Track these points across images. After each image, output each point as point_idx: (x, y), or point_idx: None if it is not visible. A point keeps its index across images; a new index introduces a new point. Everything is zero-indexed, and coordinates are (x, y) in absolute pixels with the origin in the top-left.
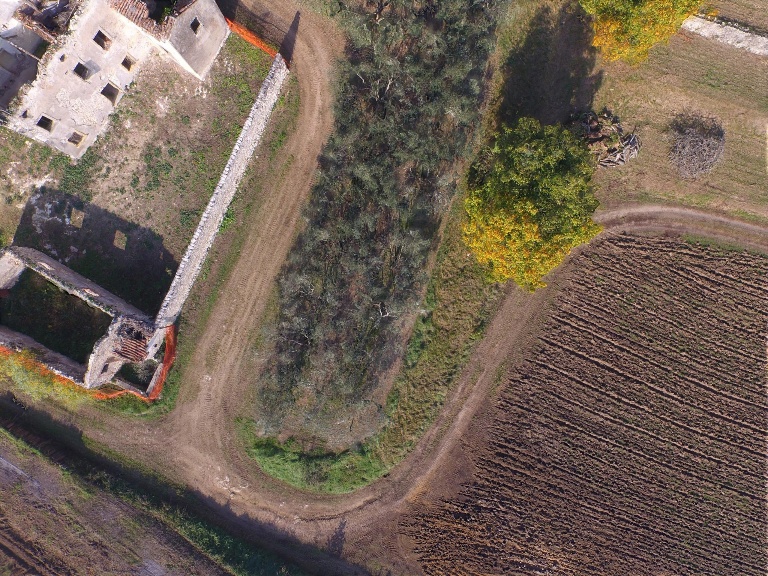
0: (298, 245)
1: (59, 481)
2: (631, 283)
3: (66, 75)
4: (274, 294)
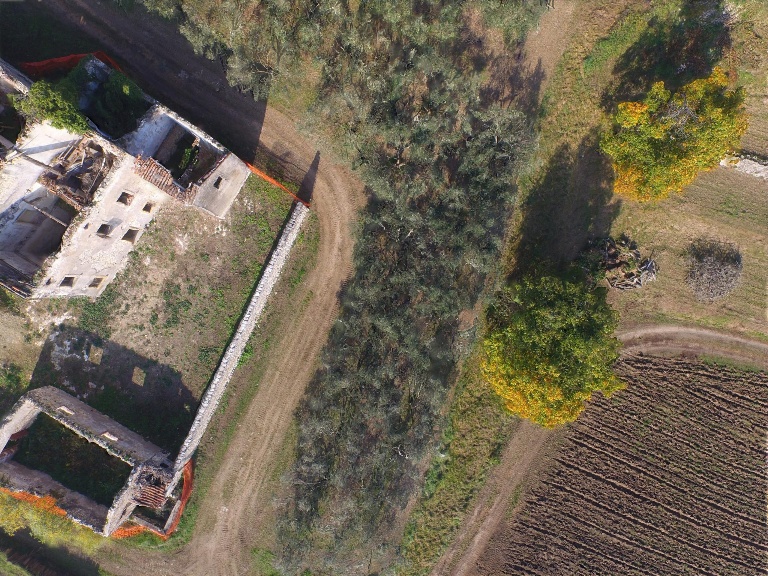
0: (316, 379)
1: None
2: (648, 405)
3: (89, 238)
4: (292, 427)
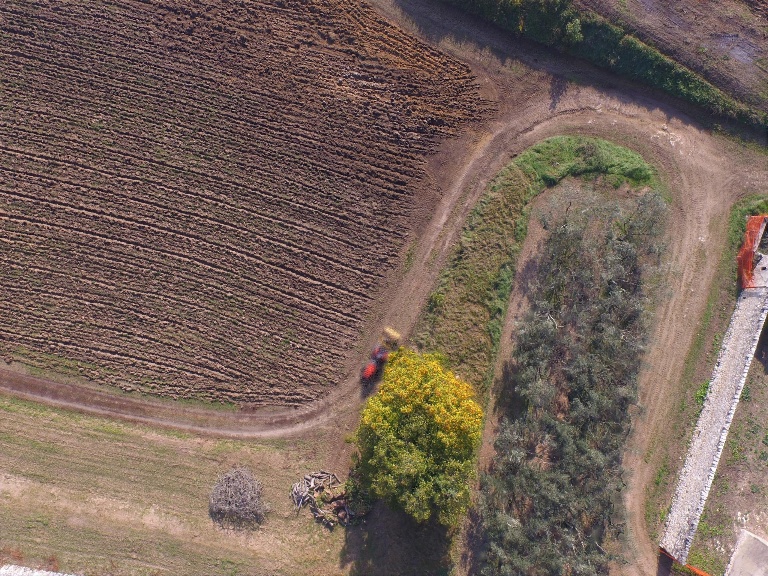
0: None
1: None
2: (287, 359)
3: None
4: None
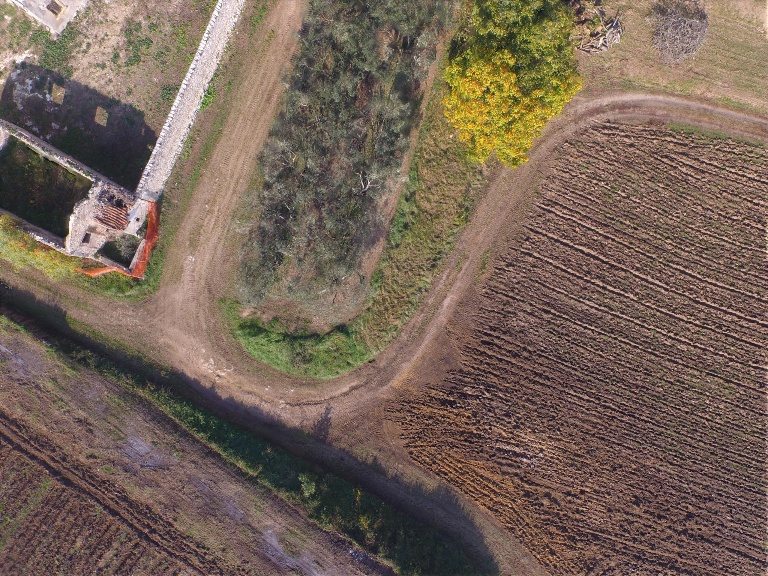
0: (280, 122)
1: (43, 358)
2: (615, 170)
3: None
4: (256, 173)
